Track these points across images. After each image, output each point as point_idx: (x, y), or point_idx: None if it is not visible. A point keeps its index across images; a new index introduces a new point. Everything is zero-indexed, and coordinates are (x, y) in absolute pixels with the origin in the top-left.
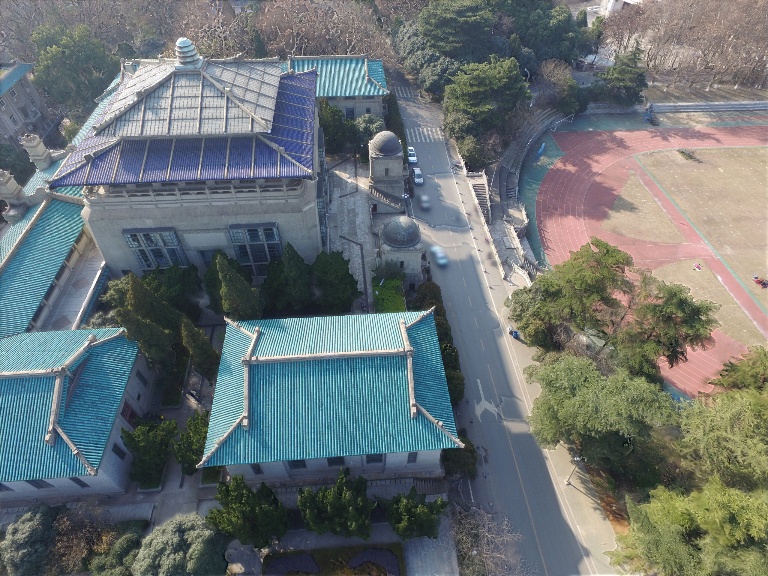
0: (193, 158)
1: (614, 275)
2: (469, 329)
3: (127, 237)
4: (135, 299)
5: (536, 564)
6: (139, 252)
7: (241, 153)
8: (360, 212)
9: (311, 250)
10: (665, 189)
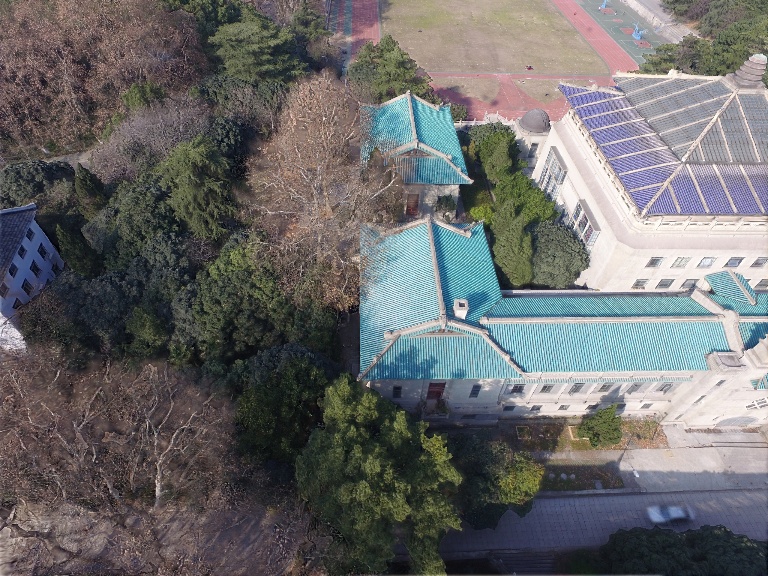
0: None
1: None
2: None
3: None
4: None
5: None
6: None
7: None
8: None
9: None
10: (437, 71)
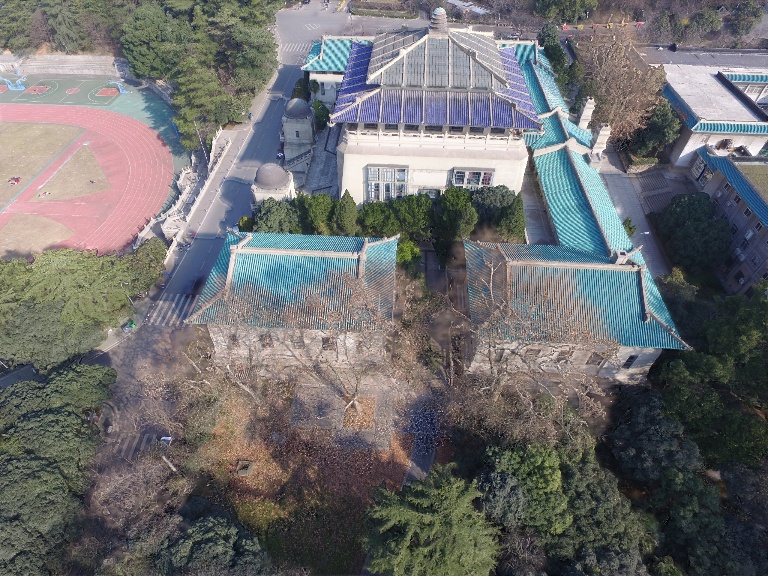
0: None
1: None
2: (275, 123)
3: None
4: None
5: None
6: None
7: None
8: (317, 172)
9: None
10: None
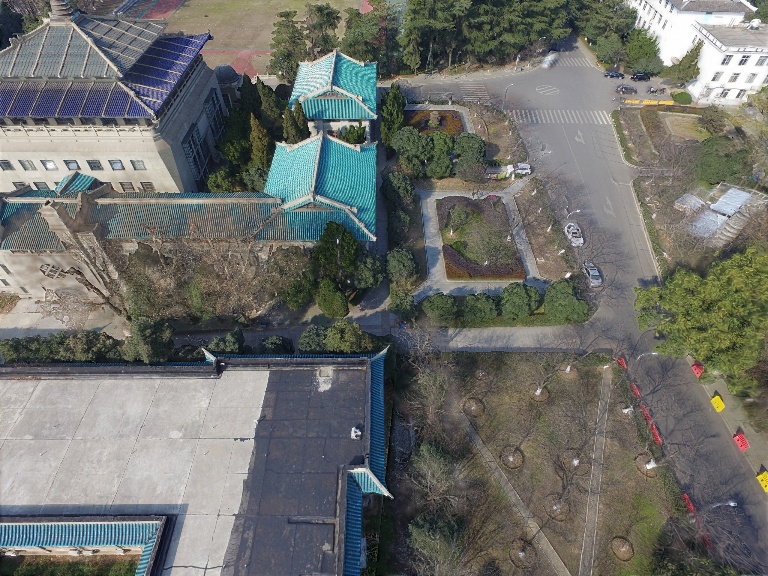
0: (164, 62)
1: (294, 26)
2: None
3: (188, 146)
4: (264, 129)
5: (411, 94)
6: (193, 160)
7: (171, 47)
8: None
9: (224, 105)
10: None
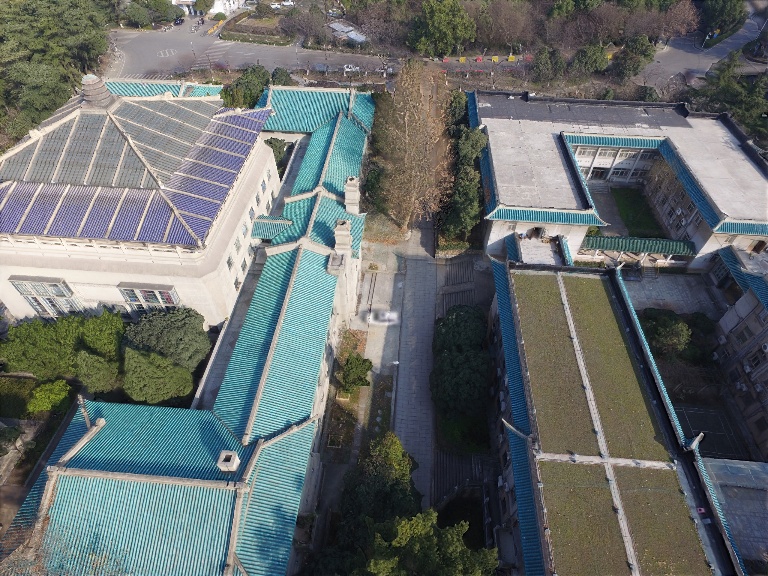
0: None
1: None
2: None
3: None
4: None
5: None
6: None
7: None
8: None
9: None
10: None
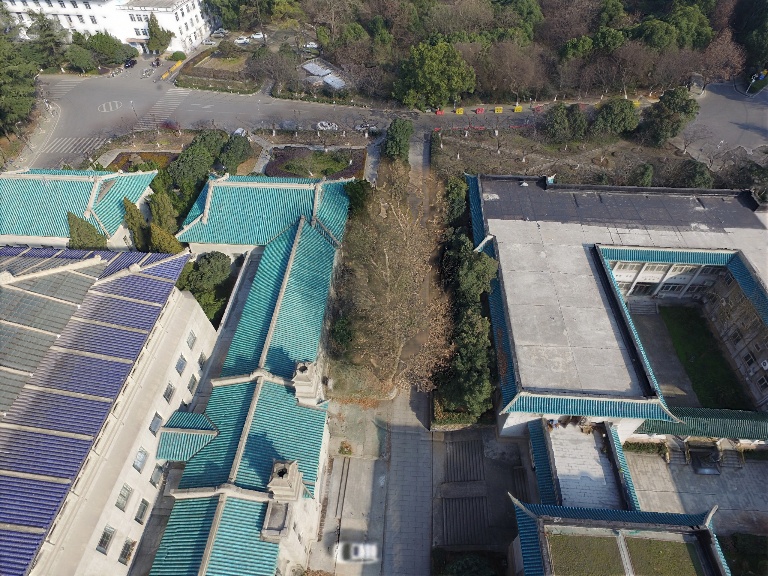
0: None
1: None
2: None
3: None
4: None
5: None
6: None
7: None
8: None
9: None
10: None
